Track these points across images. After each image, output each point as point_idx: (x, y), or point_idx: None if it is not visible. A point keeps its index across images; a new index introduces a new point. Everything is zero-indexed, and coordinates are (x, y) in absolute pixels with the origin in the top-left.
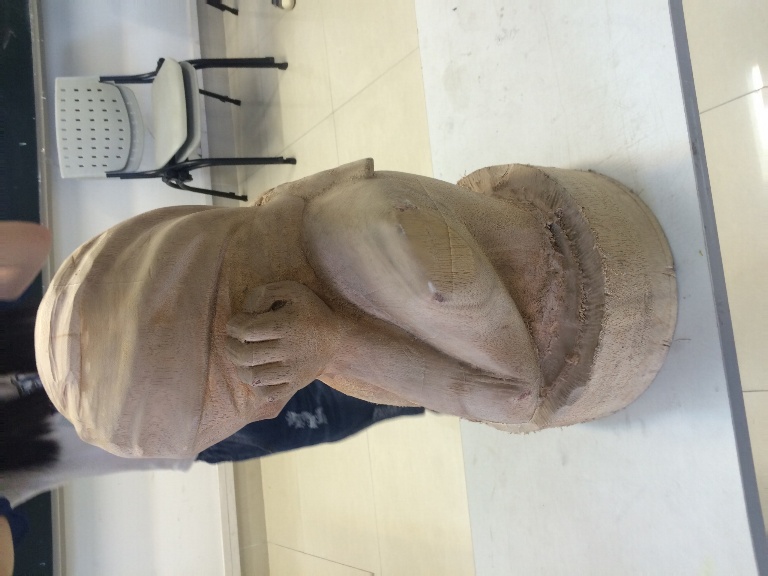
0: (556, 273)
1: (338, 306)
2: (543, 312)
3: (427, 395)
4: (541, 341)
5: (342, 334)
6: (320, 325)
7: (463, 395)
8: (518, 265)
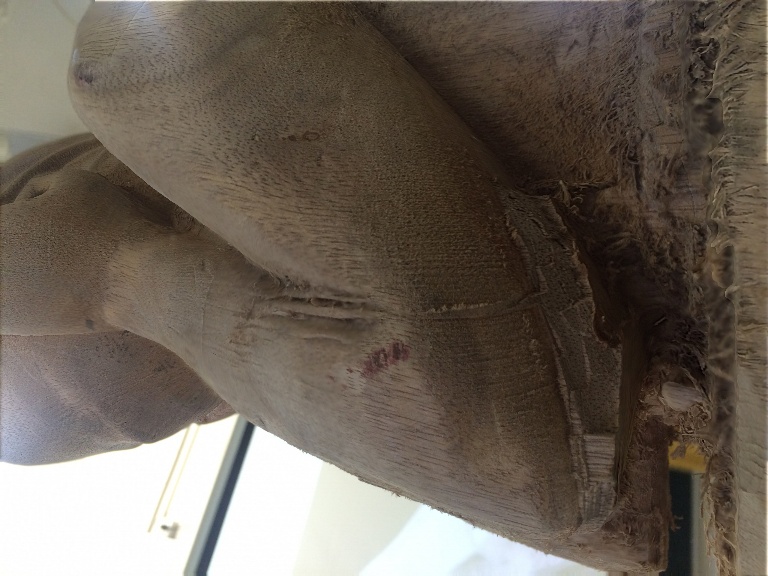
0: (657, 8)
1: (177, 219)
2: (637, 147)
3: (210, 367)
4: (685, 262)
5: (122, 246)
6: (72, 222)
7: (249, 360)
8: (533, 40)
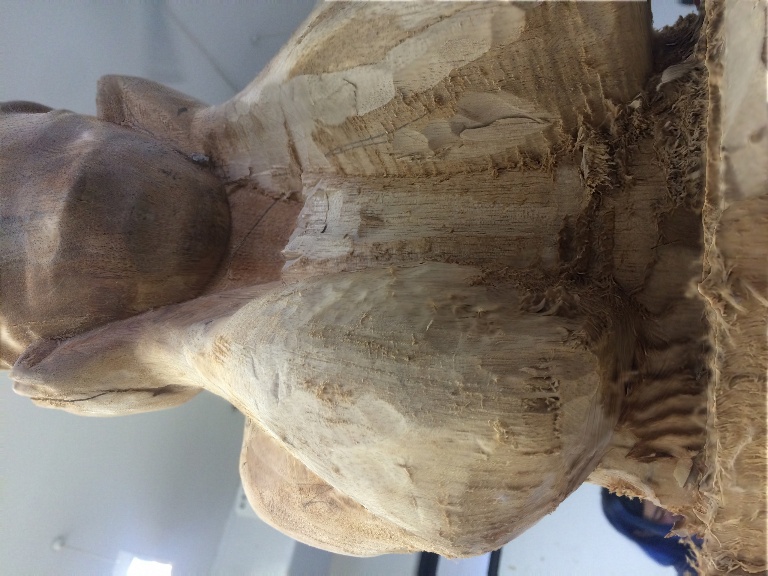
0: None
1: None
2: None
3: None
4: None
5: None
6: None
7: None
8: None
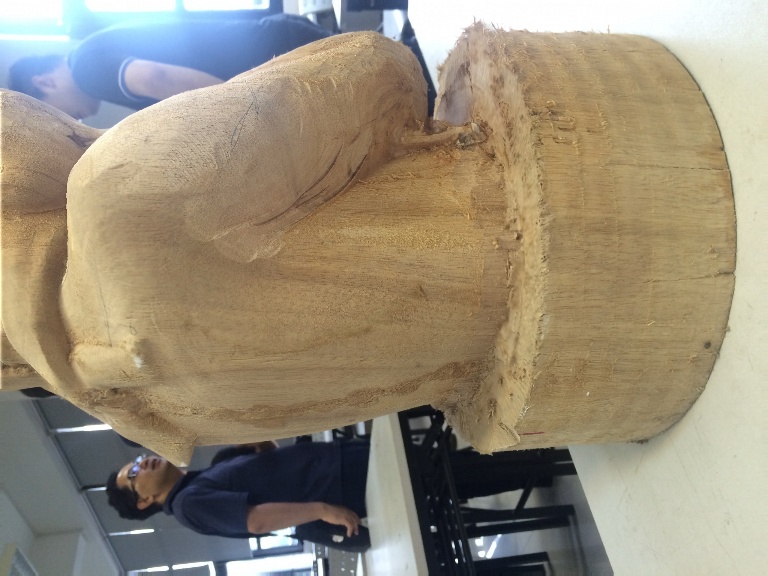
0: None
1: None
2: None
3: None
4: None
5: None
6: None
7: None
8: None
